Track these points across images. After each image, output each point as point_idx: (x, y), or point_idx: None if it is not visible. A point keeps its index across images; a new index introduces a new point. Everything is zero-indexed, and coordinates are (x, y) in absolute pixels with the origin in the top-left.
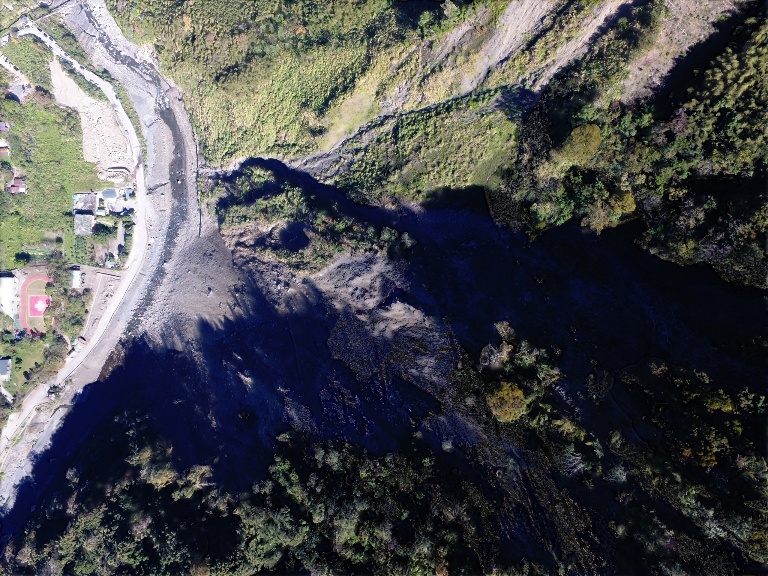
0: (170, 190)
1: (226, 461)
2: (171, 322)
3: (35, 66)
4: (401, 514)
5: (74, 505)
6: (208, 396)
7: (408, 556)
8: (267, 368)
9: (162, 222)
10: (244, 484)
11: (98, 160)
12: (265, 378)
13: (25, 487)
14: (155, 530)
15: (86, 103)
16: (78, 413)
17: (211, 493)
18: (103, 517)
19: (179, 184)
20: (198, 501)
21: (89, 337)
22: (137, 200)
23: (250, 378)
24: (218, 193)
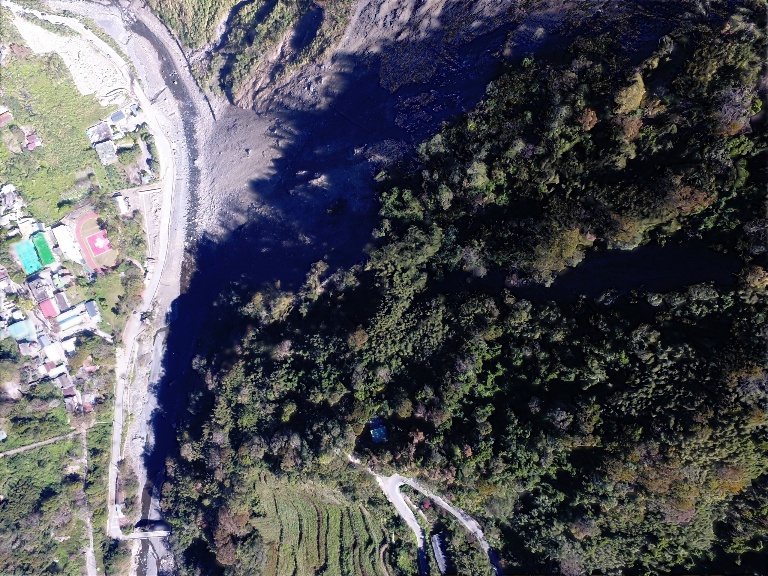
0: (171, 94)
1: (335, 256)
2: (224, 208)
3: (1, 26)
4: (525, 116)
5: (213, 378)
6: (290, 227)
7: (549, 148)
8: (335, 155)
9: (176, 125)
10: (362, 254)
11: (94, 90)
12: (337, 163)
13: (158, 420)
14: (298, 345)
15: (61, 44)
16: (176, 331)
17: (335, 277)
18: (244, 370)
19: (176, 85)
20: (326, 300)
21: (156, 255)
22: (145, 113)
23: (323, 175)
24: (216, 65)
